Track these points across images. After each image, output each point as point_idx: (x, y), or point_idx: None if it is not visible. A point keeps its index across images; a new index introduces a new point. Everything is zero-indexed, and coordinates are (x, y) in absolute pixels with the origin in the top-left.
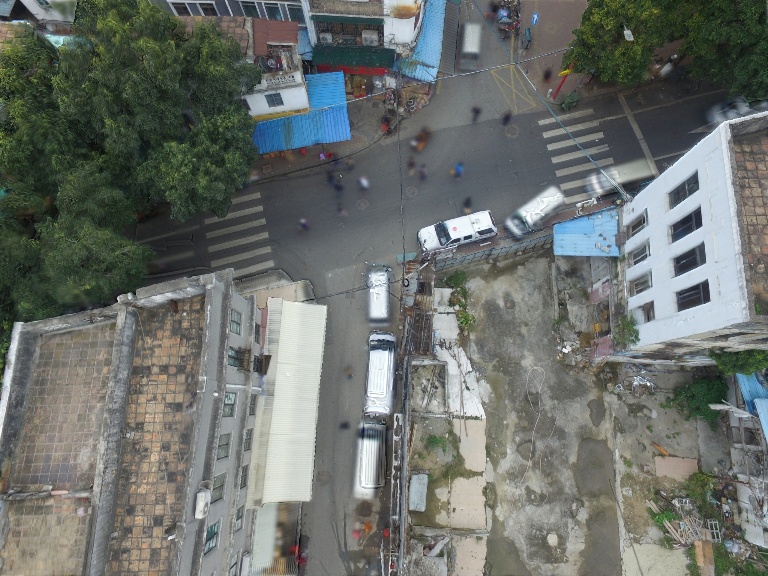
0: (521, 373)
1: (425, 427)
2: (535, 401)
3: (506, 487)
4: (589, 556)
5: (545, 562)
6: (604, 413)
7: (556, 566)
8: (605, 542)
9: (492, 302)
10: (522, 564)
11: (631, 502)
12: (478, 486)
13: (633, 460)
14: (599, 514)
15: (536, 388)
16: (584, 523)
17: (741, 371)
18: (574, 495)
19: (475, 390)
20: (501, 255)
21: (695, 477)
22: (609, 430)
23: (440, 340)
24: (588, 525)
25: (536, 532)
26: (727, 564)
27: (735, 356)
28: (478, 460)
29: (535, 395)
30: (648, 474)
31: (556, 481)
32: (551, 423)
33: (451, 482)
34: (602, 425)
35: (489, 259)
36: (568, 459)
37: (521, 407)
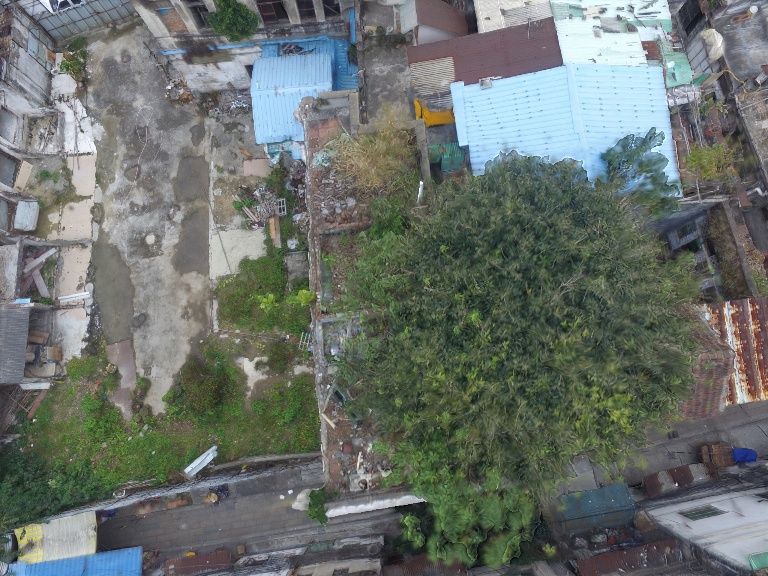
0: (132, 113)
1: (40, 167)
2: (143, 133)
3: (112, 205)
4: (182, 248)
5: (143, 258)
6: (204, 135)
7: (152, 259)
8: (197, 235)
9: (110, 59)
10: (123, 262)
11: (221, 200)
12: (86, 207)
13: (225, 167)
14: (193, 214)
15: (144, 123)
16: (179, 223)
17: (222, 26)
18: (172, 202)
19: (89, 132)
20: (117, 17)
21: (273, 170)
22: (207, 147)
23: (59, 96)
24: (183, 224)
25: (136, 236)
26: (291, 231)
27: (214, 13)
28: (88, 187)
29: (143, 129)
30: (237, 176)
31: (157, 194)
32: (156, 149)
33: (62, 207)
34: (201, 144)
35: (108, 23)
36: (169, 175)
37: (130, 140)
